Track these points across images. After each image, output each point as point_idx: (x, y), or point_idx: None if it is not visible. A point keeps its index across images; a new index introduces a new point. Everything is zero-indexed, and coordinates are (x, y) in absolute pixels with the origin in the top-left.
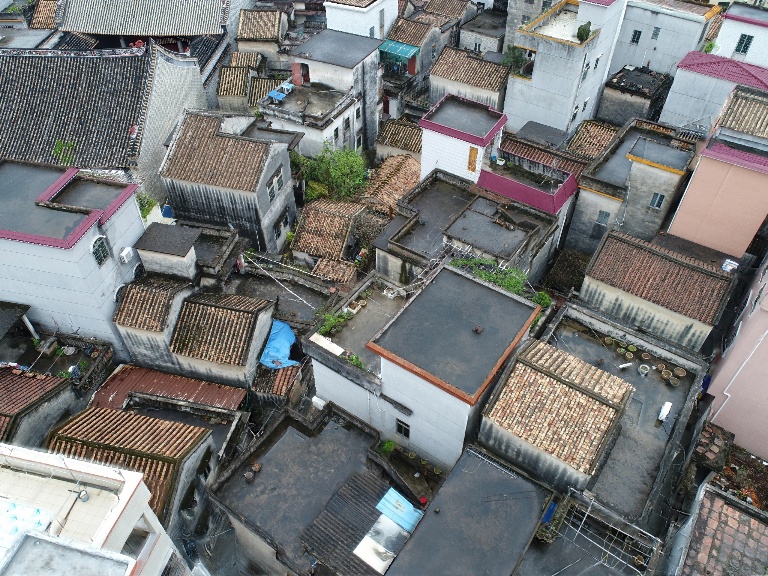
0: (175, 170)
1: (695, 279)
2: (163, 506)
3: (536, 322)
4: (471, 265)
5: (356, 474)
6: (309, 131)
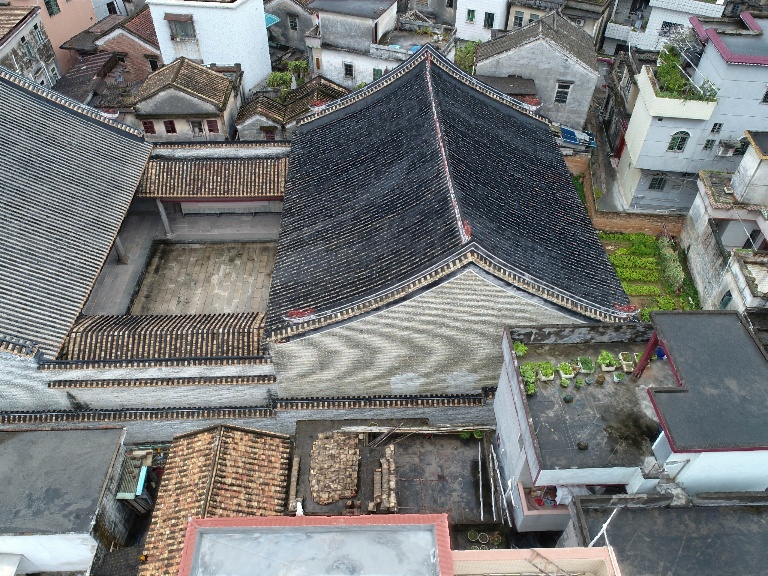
0: None
1: None
2: None
3: None
4: None
5: None
6: None
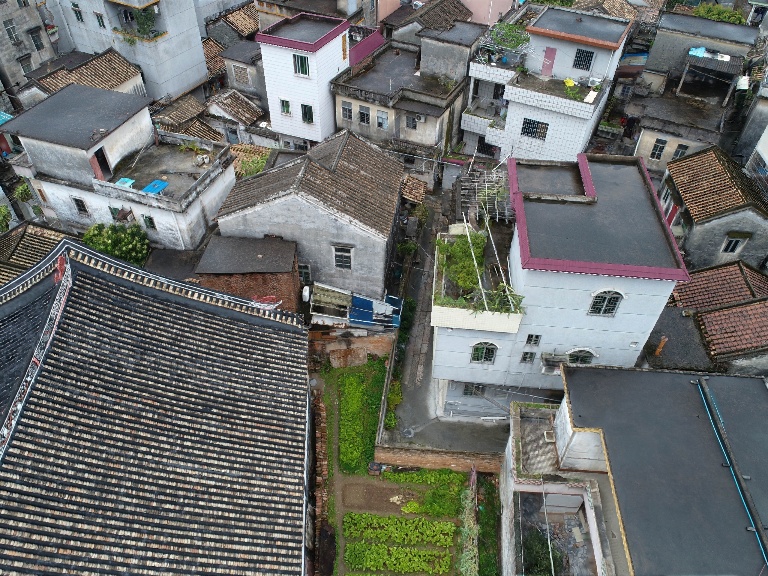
0: (380, 223)
1: (447, 5)
2: (736, 163)
3: None
4: None
5: (690, 62)
6: (223, 177)
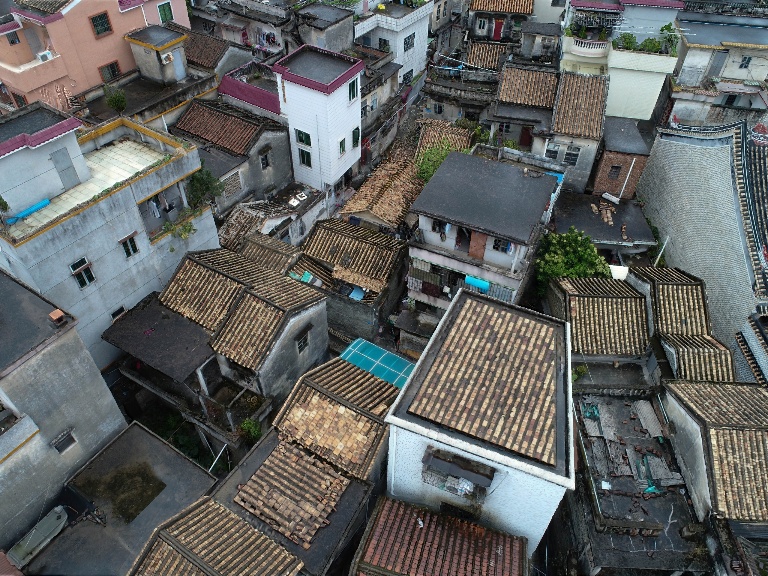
0: None
1: None
2: None
3: (307, 2)
4: (339, 1)
5: None
6: None
